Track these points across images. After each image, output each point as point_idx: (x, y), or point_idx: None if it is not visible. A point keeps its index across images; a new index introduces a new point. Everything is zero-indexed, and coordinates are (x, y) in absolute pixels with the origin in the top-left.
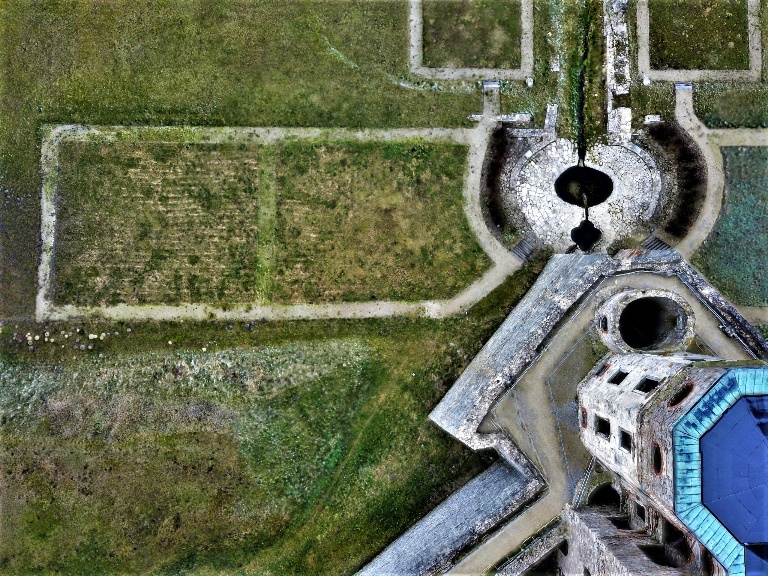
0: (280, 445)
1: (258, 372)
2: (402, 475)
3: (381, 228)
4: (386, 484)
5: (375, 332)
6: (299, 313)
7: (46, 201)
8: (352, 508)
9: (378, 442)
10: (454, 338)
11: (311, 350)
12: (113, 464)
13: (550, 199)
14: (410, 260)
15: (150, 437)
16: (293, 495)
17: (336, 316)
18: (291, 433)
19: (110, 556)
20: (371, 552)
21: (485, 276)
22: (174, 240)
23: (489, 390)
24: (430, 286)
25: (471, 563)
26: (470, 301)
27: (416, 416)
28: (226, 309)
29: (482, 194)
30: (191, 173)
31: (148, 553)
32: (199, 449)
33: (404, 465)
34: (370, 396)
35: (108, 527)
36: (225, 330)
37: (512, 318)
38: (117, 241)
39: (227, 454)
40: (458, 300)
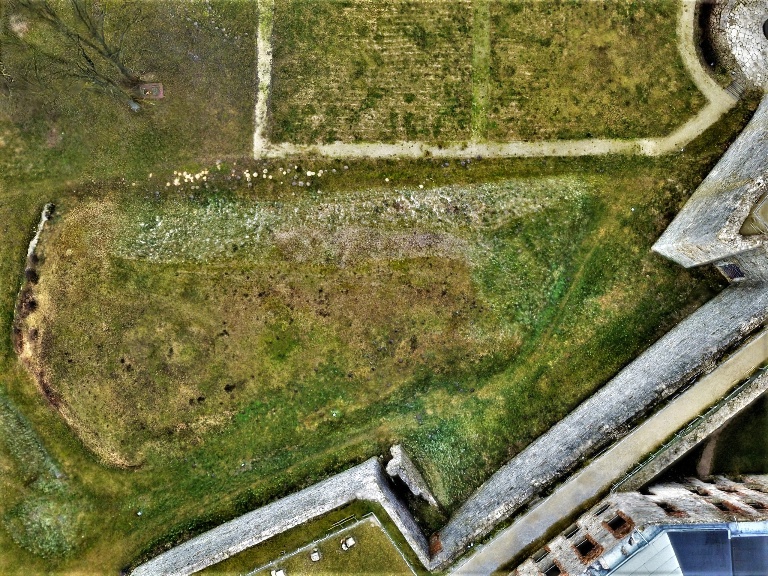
0: (509, 273)
1: (480, 205)
2: (630, 303)
3: (596, 66)
4: (614, 312)
5: (591, 169)
6: (514, 151)
7: (263, 40)
8: (582, 335)
9: (600, 275)
10: (671, 174)
11: (529, 186)
12: (349, 287)
13: (759, 41)
14: (625, 98)
15: (383, 262)
16: (524, 321)
17: (551, 154)
18: (518, 262)
19: (349, 376)
20: (604, 377)
21: (700, 114)
22: (390, 78)
23: (750, 193)
24: (645, 124)
25: (734, 364)
26: (685, 139)
27: (638, 249)
28: (442, 147)
29: (695, 33)
30: (406, 12)
31: (387, 373)
32: (432, 273)
33: (631, 294)
34: (590, 231)
35: (346, 348)
36: (441, 167)
37: (738, 148)
38: (333, 79)
39: (460, 278)
40: (673, 138)
